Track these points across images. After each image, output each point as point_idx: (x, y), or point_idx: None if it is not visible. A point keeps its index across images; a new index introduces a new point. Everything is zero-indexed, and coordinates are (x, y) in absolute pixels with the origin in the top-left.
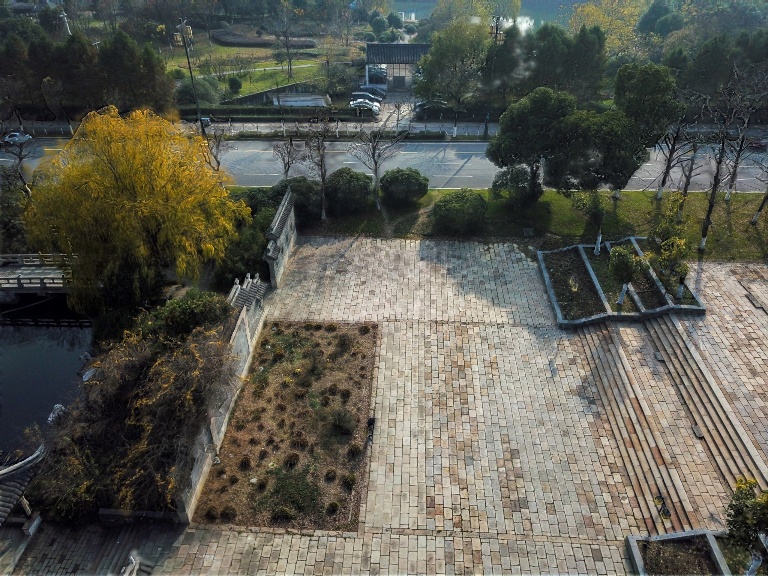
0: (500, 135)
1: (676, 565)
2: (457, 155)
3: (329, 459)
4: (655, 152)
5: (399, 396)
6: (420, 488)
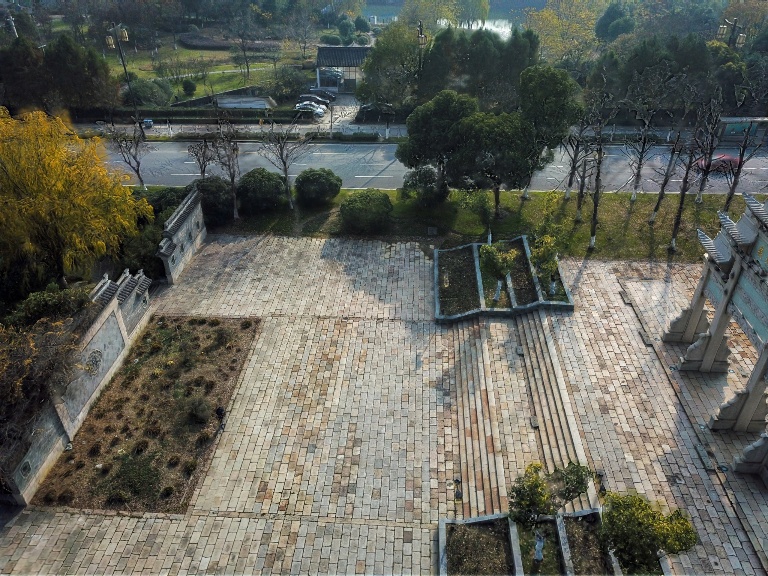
0: (409, 136)
1: (476, 546)
2: (385, 156)
3: (177, 446)
4: (560, 153)
5: (262, 387)
6: (257, 474)
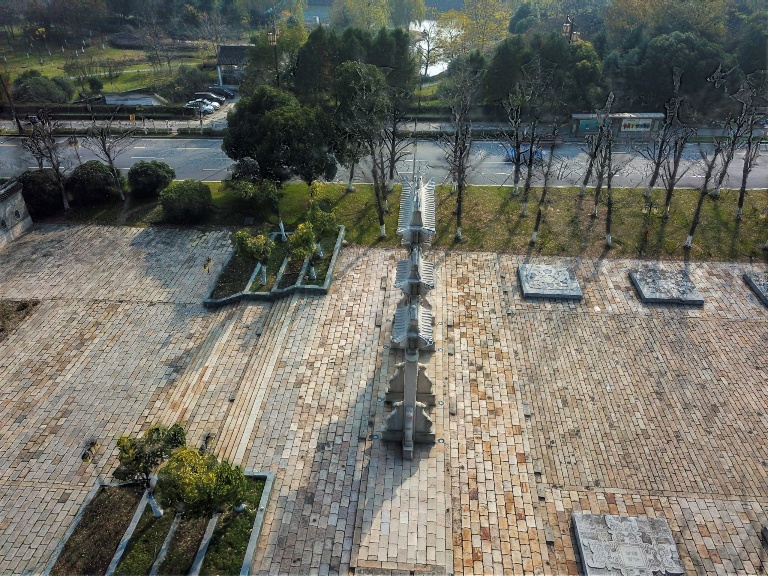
0: None
1: (114, 505)
2: None
3: None
4: (379, 147)
5: (6, 364)
6: None
